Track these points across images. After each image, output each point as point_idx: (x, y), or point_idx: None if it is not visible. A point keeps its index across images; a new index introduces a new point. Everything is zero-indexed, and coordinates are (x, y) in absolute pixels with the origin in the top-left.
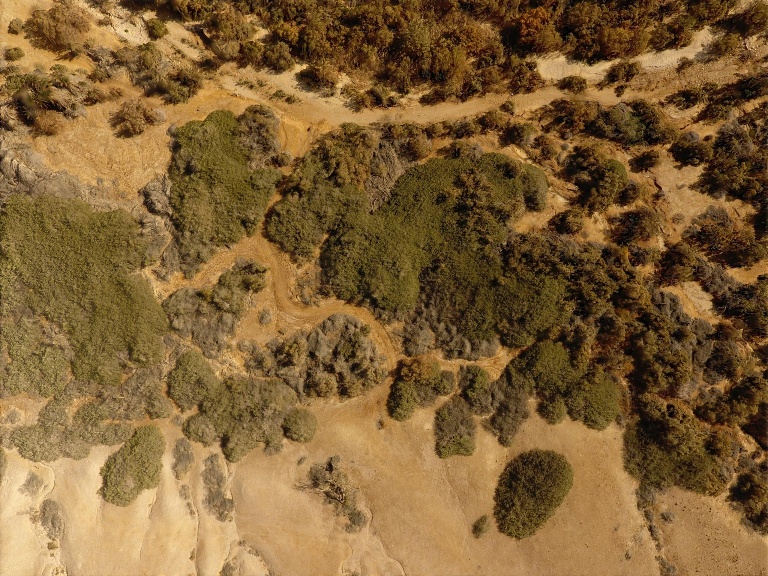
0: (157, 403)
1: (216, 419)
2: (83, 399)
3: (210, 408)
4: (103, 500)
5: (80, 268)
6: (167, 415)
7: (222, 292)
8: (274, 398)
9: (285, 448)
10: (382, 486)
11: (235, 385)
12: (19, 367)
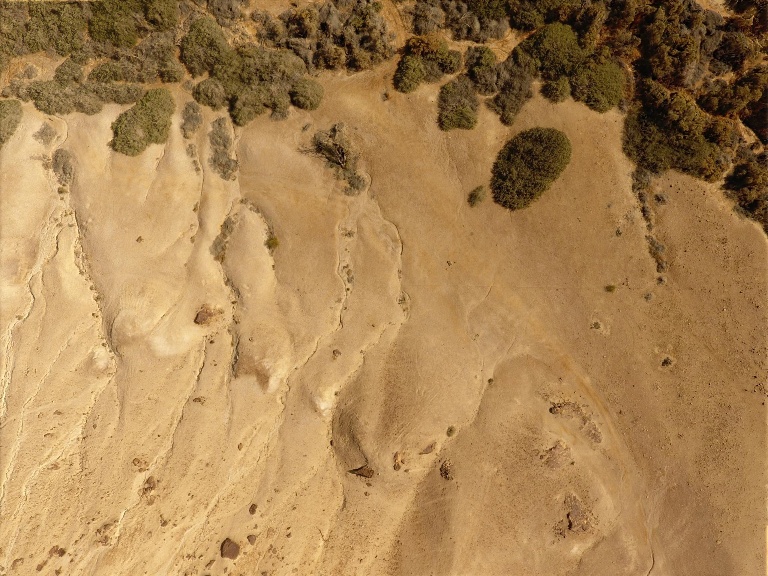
0: (170, 63)
1: (226, 81)
2: (98, 60)
3: (221, 70)
4: (113, 151)
5: None
6: (179, 78)
7: None
8: (283, 61)
9: (291, 115)
10: (383, 153)
11: (246, 49)
12: (38, 23)
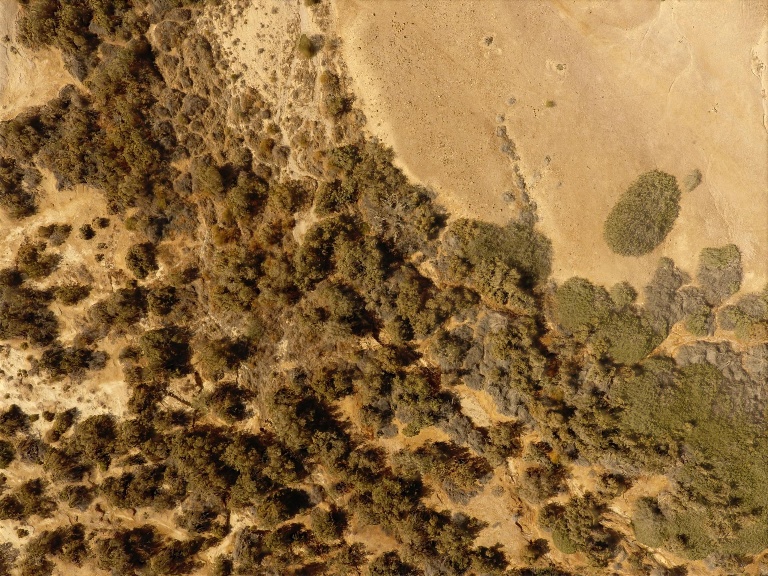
0: None
1: None
2: None
3: None
4: None
5: None
6: None
7: None
8: None
9: None
10: None
11: None
12: None
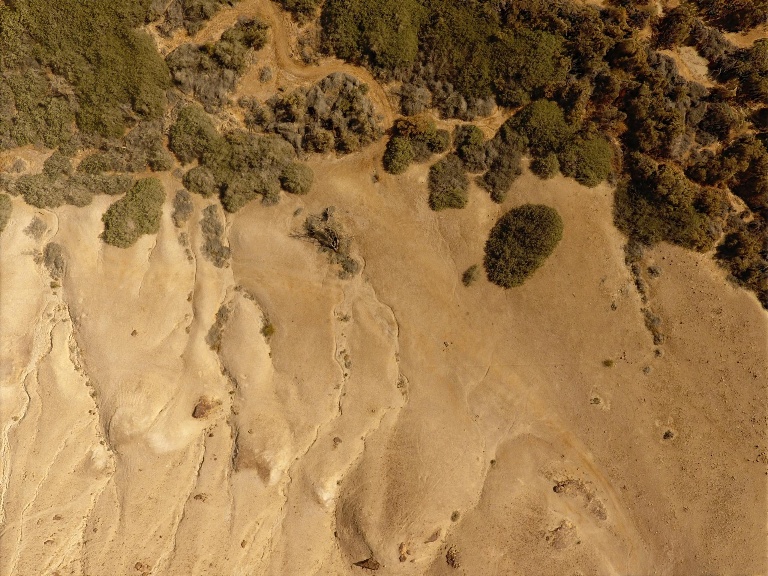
0: (158, 153)
1: (215, 169)
2: (87, 151)
3: (210, 158)
4: (104, 243)
5: (86, 20)
6: (168, 166)
7: (224, 43)
8: (272, 148)
9: (282, 200)
10: (375, 235)
11: (235, 136)
12: (25, 117)
